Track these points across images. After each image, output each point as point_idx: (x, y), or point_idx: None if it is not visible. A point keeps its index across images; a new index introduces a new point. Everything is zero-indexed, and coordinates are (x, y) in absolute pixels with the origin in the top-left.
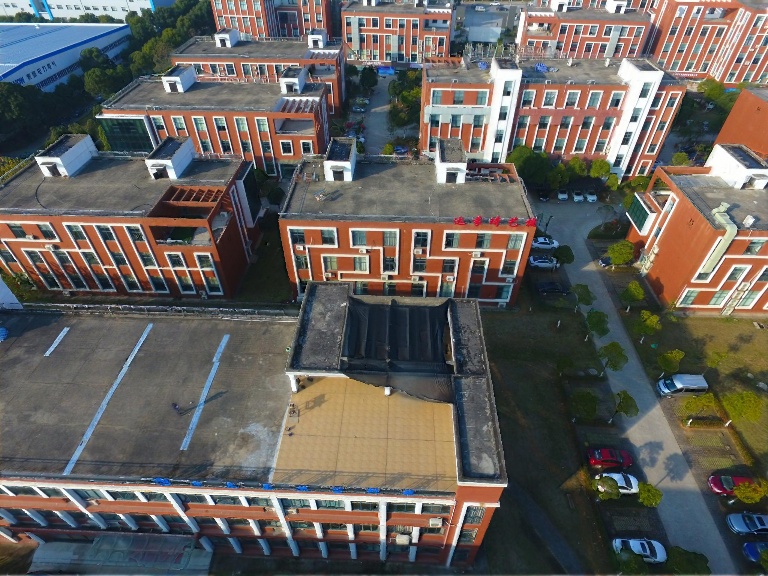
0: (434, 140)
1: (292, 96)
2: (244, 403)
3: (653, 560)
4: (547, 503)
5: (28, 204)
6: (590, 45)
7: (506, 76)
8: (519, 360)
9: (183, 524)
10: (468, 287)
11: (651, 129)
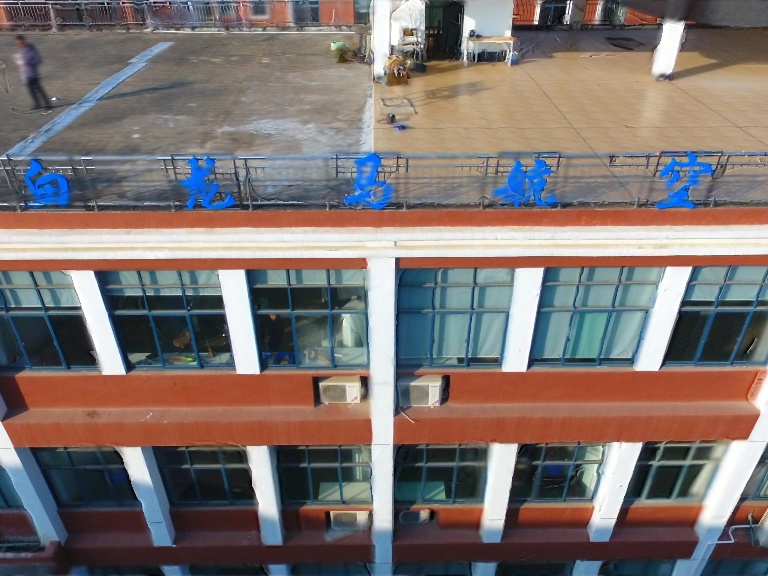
0: None
1: None
2: (227, 98)
3: None
4: None
5: None
6: None
7: None
8: None
9: (6, 513)
10: None
11: None
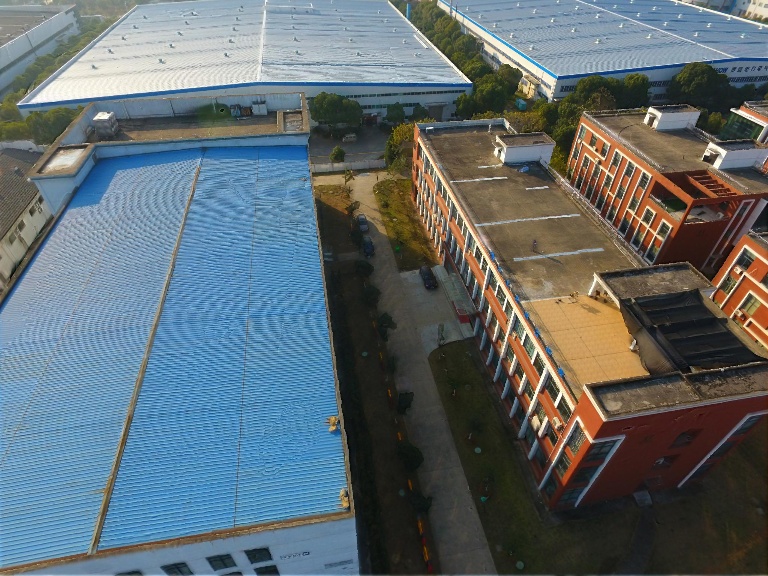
0: None
1: None
2: (561, 274)
3: None
4: None
5: (614, 130)
6: None
7: None
8: None
9: None
10: None
11: None
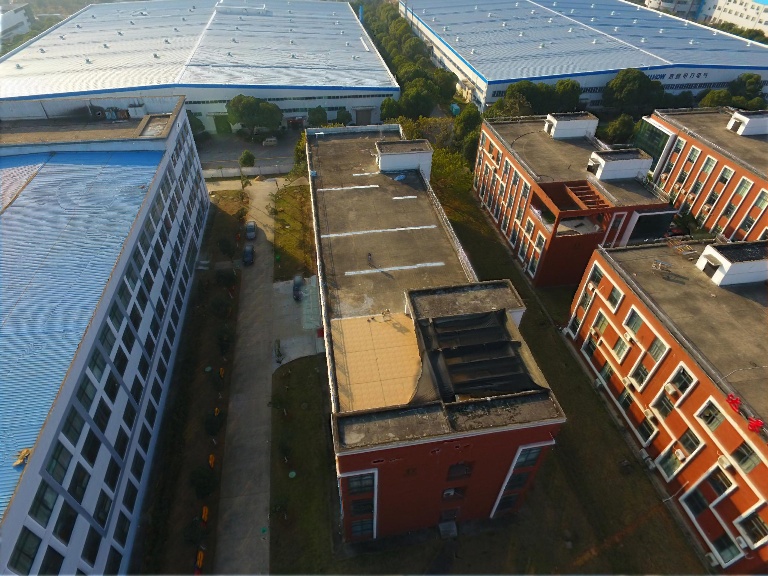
0: None
1: None
2: (387, 290)
3: None
4: None
5: (511, 137)
6: None
7: None
8: None
9: None
10: (692, 489)
11: None
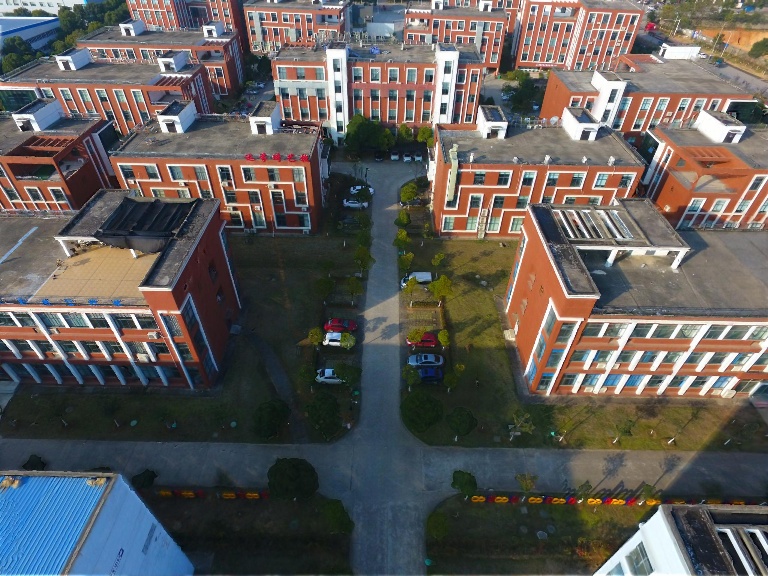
0: (288, 111)
1: (168, 73)
2: (30, 263)
3: (338, 380)
4: (282, 353)
5: None
6: (460, 38)
7: (334, 55)
8: (304, 268)
9: None
10: (275, 216)
11: (463, 101)
